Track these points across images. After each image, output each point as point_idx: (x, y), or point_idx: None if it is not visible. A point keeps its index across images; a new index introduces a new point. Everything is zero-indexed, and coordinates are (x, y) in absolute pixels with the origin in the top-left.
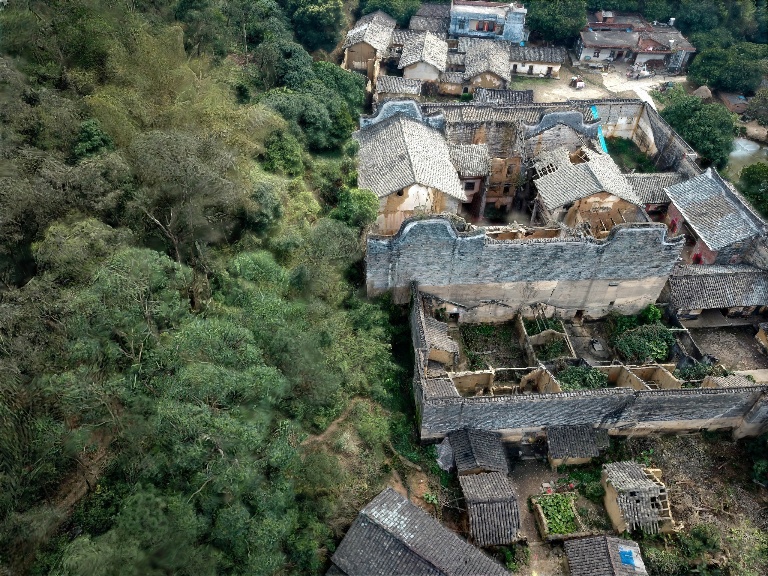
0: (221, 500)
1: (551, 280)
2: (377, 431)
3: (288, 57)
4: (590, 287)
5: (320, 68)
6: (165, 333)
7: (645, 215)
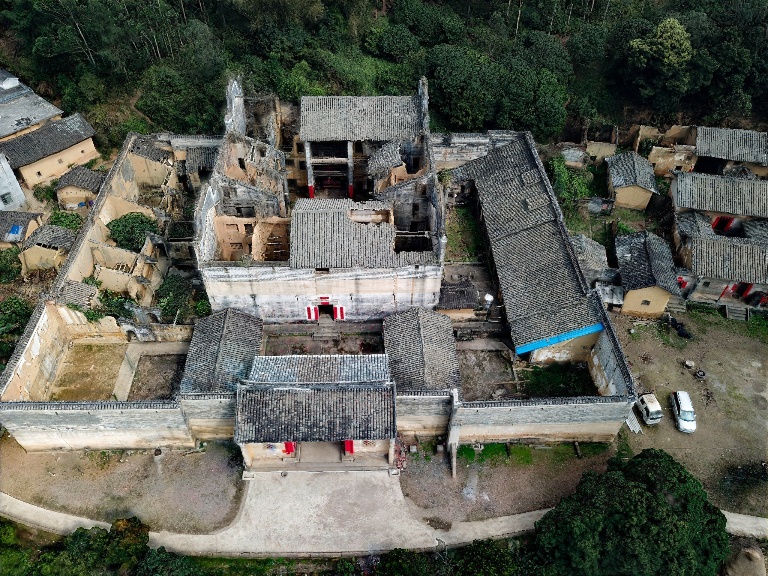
0: None
1: None
2: (126, 123)
3: None
4: None
5: None
6: None
7: (274, 261)
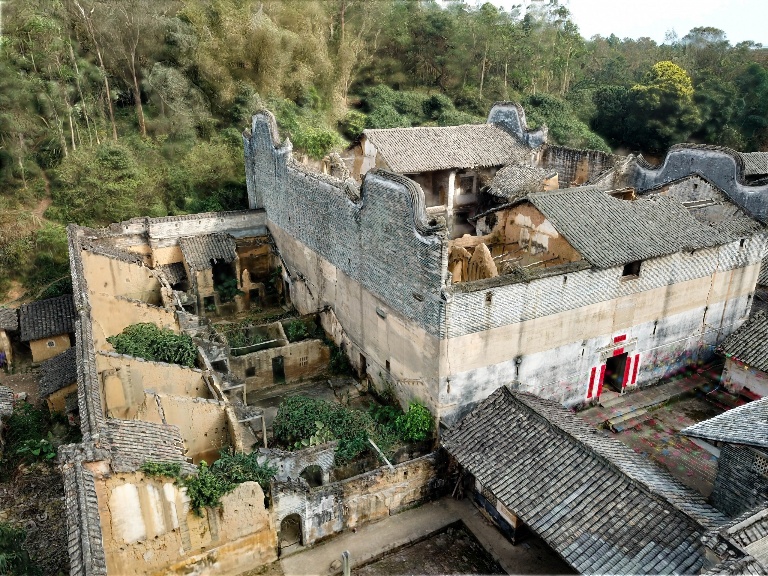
0: None
1: (332, 263)
2: None
3: (537, 106)
4: (362, 303)
5: (552, 117)
6: (105, 133)
7: None
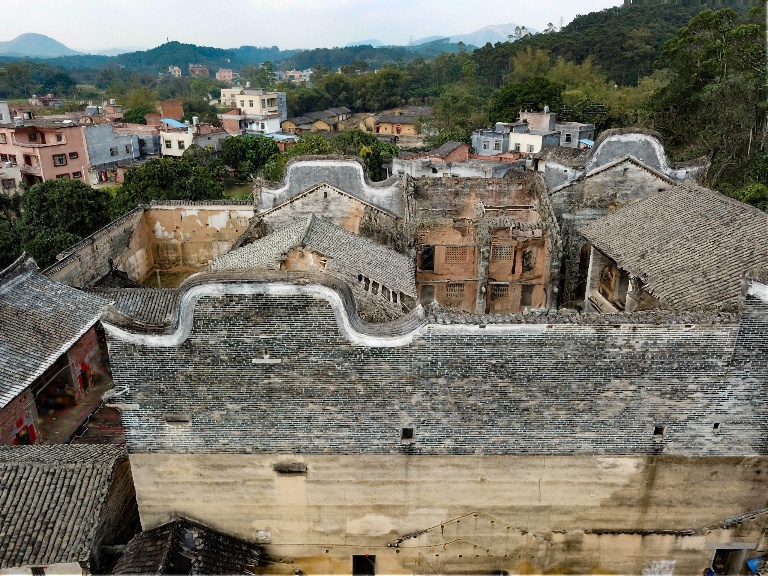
0: None
1: None
2: None
3: None
4: None
5: None
6: None
7: (238, 247)
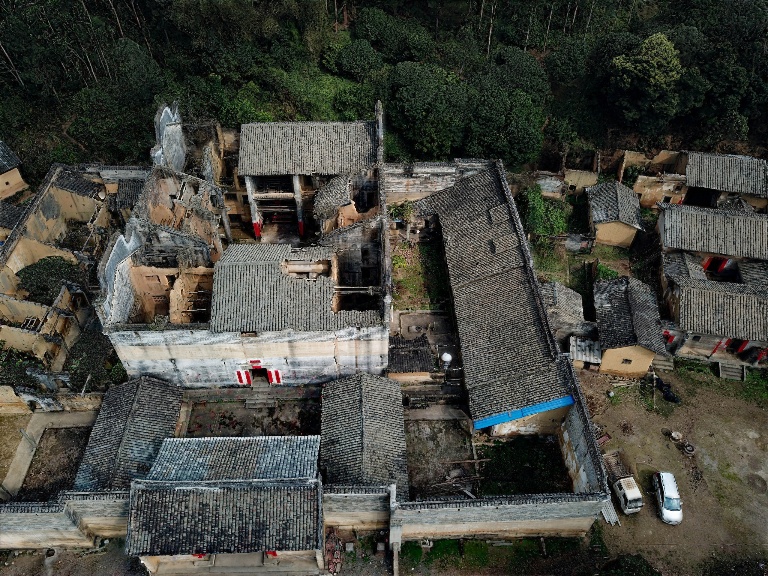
0: None
1: None
2: (55, 152)
3: None
4: None
5: None
6: None
7: (191, 323)
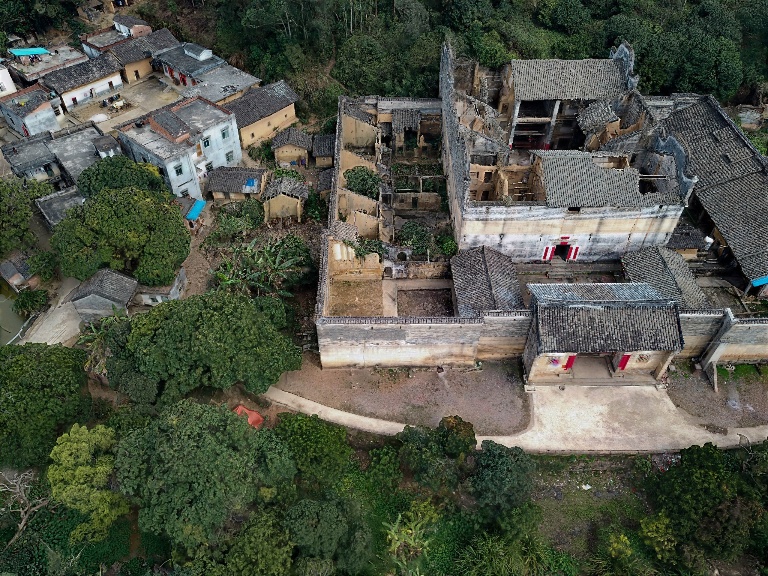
0: (267, 6)
1: None
2: (329, 89)
3: (704, 16)
4: None
5: None
6: (371, 8)
7: None
